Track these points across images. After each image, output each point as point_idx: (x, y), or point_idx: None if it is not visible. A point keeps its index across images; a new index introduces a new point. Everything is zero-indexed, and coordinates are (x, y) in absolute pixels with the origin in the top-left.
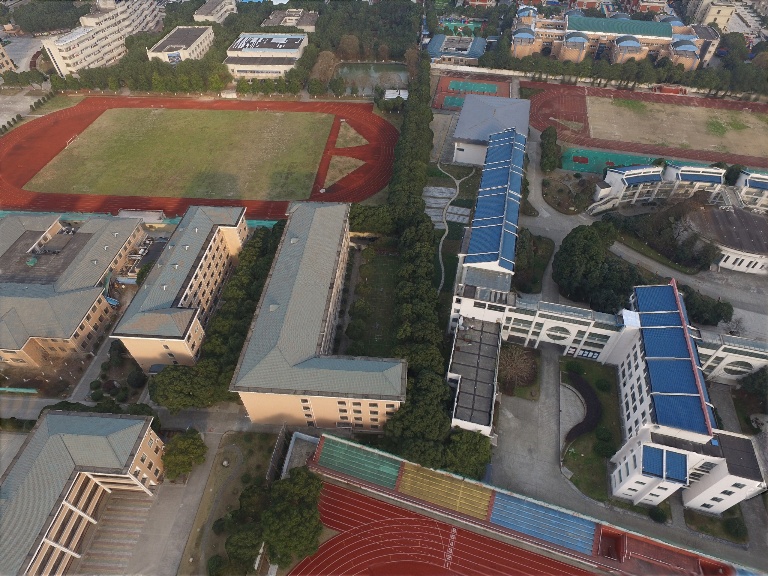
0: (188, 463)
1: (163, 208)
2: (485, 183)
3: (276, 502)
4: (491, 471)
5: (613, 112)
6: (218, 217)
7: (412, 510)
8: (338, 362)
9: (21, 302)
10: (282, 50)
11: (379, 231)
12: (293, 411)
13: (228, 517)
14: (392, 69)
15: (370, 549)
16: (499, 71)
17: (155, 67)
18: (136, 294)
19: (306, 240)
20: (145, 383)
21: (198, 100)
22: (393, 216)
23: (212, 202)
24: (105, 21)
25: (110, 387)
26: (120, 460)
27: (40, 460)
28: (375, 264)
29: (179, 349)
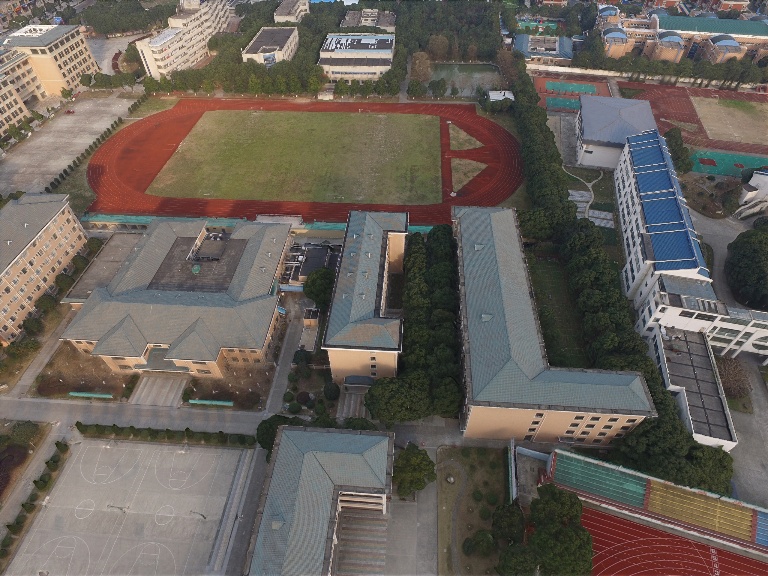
0: (422, 480)
1: (296, 213)
2: (644, 187)
3: (545, 523)
4: (735, 488)
5: (724, 113)
6: (387, 223)
7: (662, 529)
8: (573, 375)
9: (207, 312)
10: (375, 51)
11: (535, 236)
12: (518, 425)
13: (490, 538)
14: (477, 70)
15: (633, 571)
16: (593, 71)
17: (251, 69)
18: (332, 303)
19: (494, 247)
20: (339, 395)
21: (295, 102)
22: (551, 221)
23: (344, 206)
24: (190, 22)
25: (306, 399)
26: (380, 479)
27: (303, 480)
28: (537, 270)
29: (386, 360)
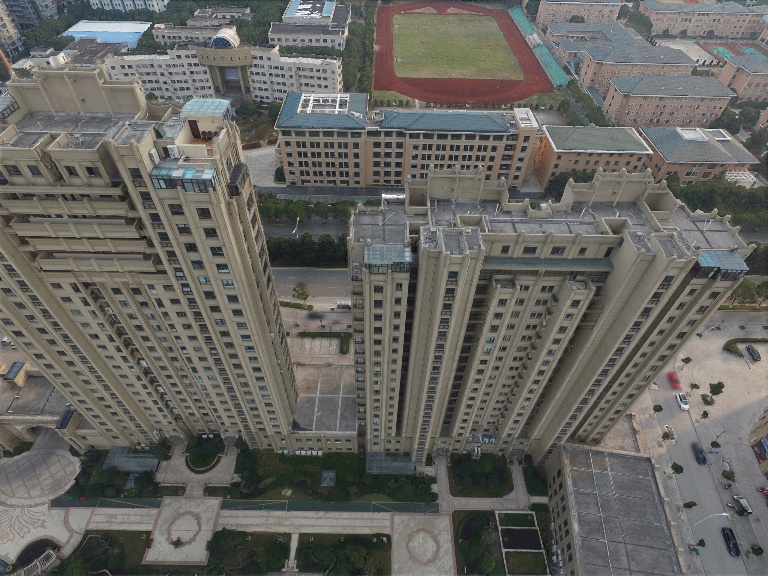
0: None
1: (517, 41)
2: None
3: None
4: None
5: None
6: None
7: None
8: None
9: None
10: (328, 5)
11: None
12: None
13: None
14: None
15: None
16: None
17: None
18: (604, 2)
19: None
20: None
21: (378, 49)
22: None
23: (505, 32)
24: None
25: None
26: None
27: None
28: None
29: None
